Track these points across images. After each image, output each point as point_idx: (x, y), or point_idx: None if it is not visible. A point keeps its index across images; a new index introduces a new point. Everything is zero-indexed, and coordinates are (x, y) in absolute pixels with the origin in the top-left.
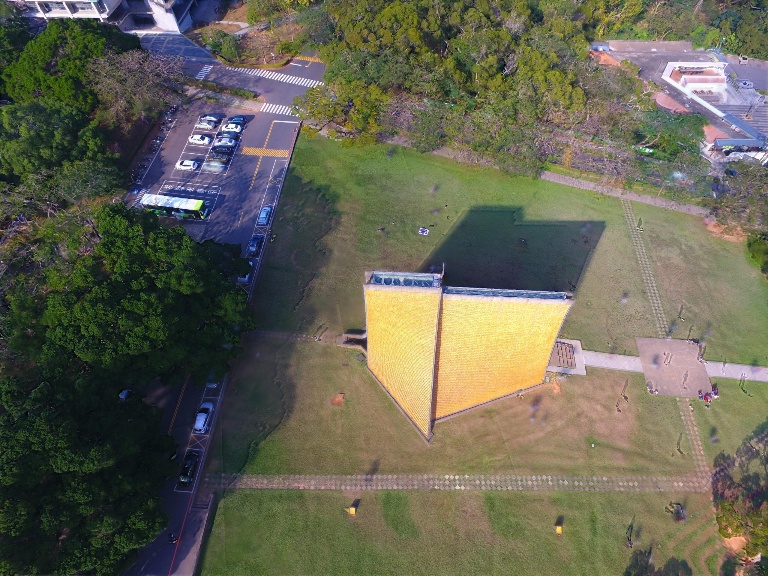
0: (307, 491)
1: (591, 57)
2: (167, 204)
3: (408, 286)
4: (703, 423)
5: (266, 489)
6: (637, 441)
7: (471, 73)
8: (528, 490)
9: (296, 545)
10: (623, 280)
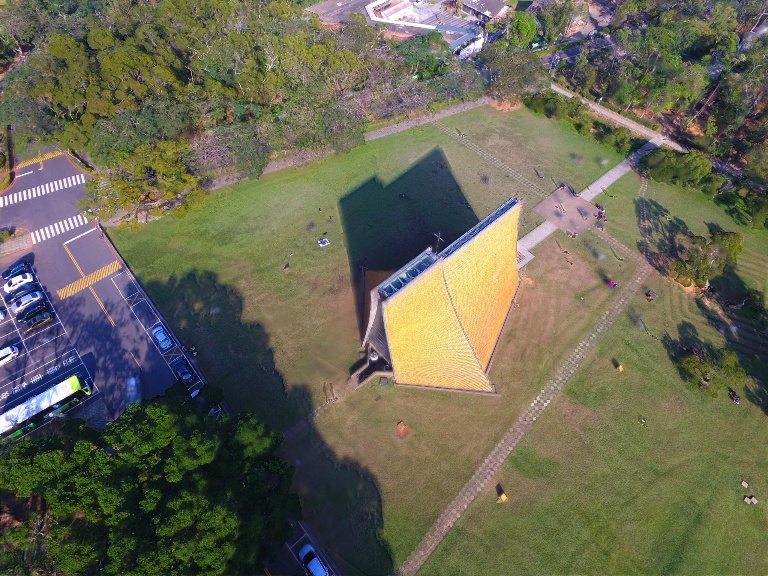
0: (458, 522)
1: (322, 24)
2: (31, 413)
3: (418, 275)
4: (613, 232)
5: (429, 558)
6: (597, 274)
7: (233, 86)
8: (582, 362)
9: (496, 569)
10: (488, 177)
